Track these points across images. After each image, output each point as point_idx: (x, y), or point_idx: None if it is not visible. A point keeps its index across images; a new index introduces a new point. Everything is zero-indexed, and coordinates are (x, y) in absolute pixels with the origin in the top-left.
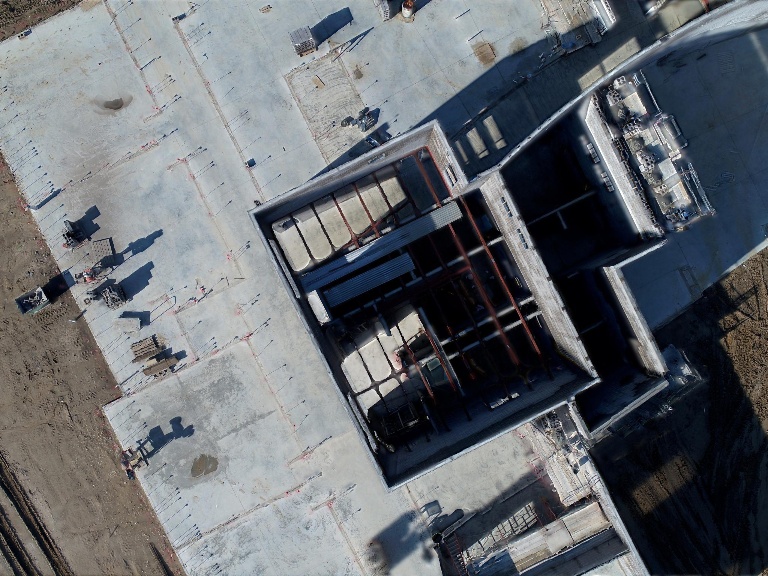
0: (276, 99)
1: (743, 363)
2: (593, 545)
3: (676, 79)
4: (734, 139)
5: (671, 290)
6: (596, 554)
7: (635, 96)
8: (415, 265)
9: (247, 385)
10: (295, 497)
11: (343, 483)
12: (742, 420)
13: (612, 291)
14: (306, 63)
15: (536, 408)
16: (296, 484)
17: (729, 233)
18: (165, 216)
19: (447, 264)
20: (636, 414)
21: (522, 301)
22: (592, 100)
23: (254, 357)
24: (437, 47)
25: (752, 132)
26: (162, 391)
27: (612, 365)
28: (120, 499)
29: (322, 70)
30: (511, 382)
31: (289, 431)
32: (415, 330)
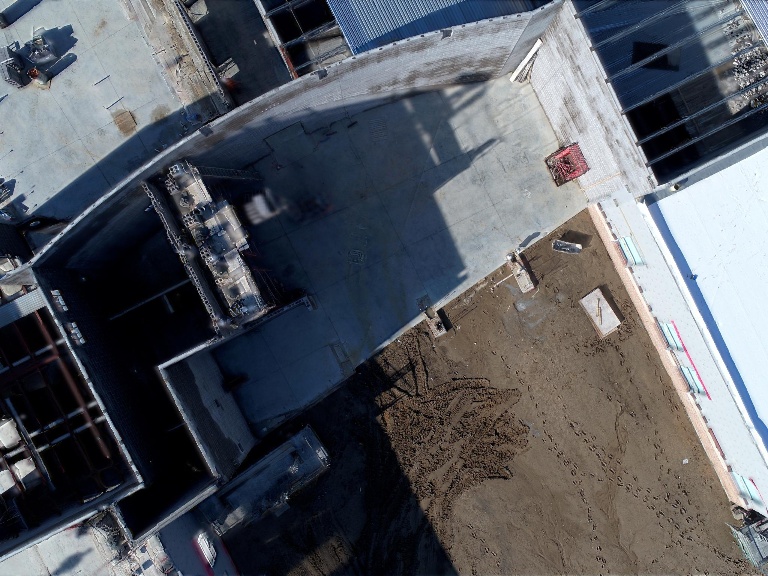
0: None
1: (401, 441)
2: None
3: (326, 147)
4: (387, 210)
5: (322, 367)
6: None
7: (200, 183)
8: None
9: None
10: None
11: None
12: (399, 499)
13: None
14: None
15: None
16: None
17: (383, 307)
18: None
19: (35, 353)
20: None
21: None
22: None
23: None
24: (75, 115)
25: (406, 202)
26: None
27: None
28: None
29: None
30: None
31: None
32: None
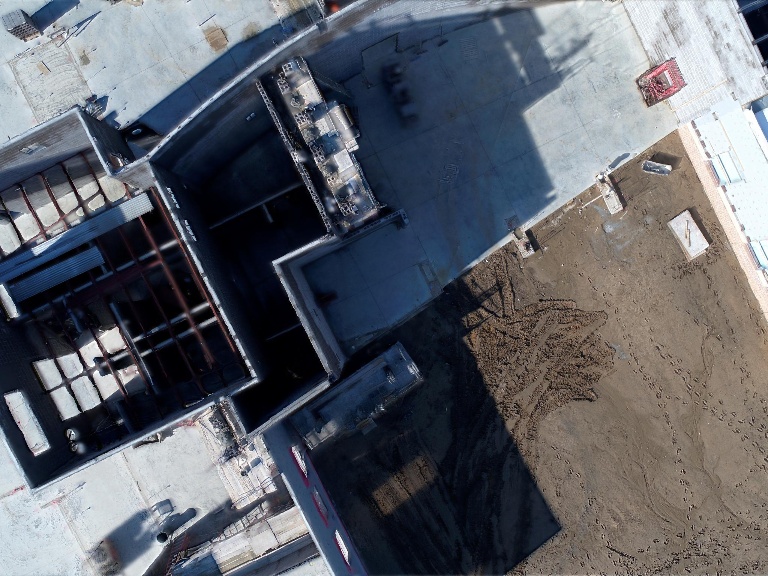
0: (0, 86)
1: (487, 361)
2: (298, 547)
3: (417, 66)
4: (477, 129)
5: (410, 286)
6: (295, 556)
7: (310, 84)
8: (104, 259)
9: None
10: (23, 494)
11: (72, 481)
12: (485, 420)
13: None
14: (31, 48)
15: (187, 409)
16: None
17: (471, 227)
18: None
19: (139, 258)
20: None
21: None
22: (258, 88)
23: None
24: (167, 32)
25: (496, 122)
26: None
27: None
28: None
29: (48, 56)
30: (234, 379)
31: None
32: None
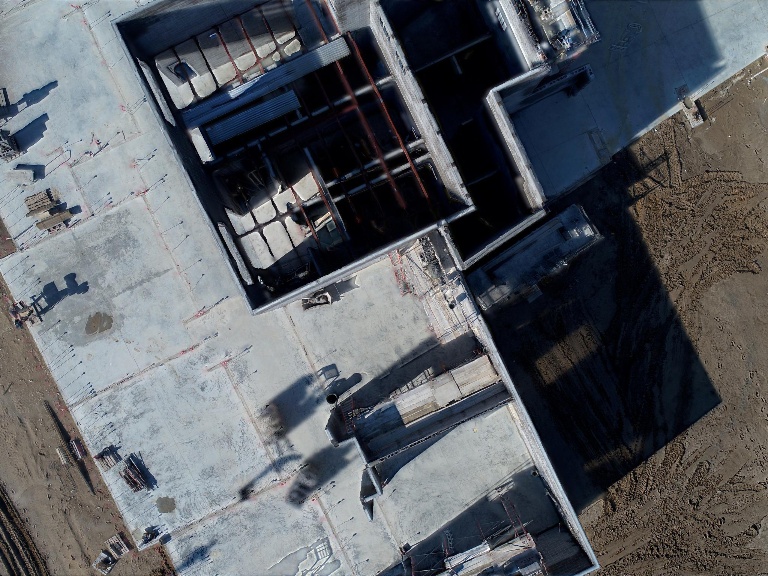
0: None
1: (652, 232)
2: (481, 399)
3: None
4: None
5: (579, 154)
6: (482, 405)
7: None
8: (301, 103)
9: (143, 242)
10: (190, 357)
11: (239, 344)
12: (649, 290)
13: (496, 124)
14: None
15: None
16: (192, 344)
17: (641, 96)
18: (60, 67)
19: (334, 103)
20: (533, 272)
21: (411, 143)
22: None
23: (150, 214)
24: None
25: None
26: (56, 247)
27: (507, 218)
28: (14, 356)
29: None
30: None
31: (185, 290)
32: (315, 189)
